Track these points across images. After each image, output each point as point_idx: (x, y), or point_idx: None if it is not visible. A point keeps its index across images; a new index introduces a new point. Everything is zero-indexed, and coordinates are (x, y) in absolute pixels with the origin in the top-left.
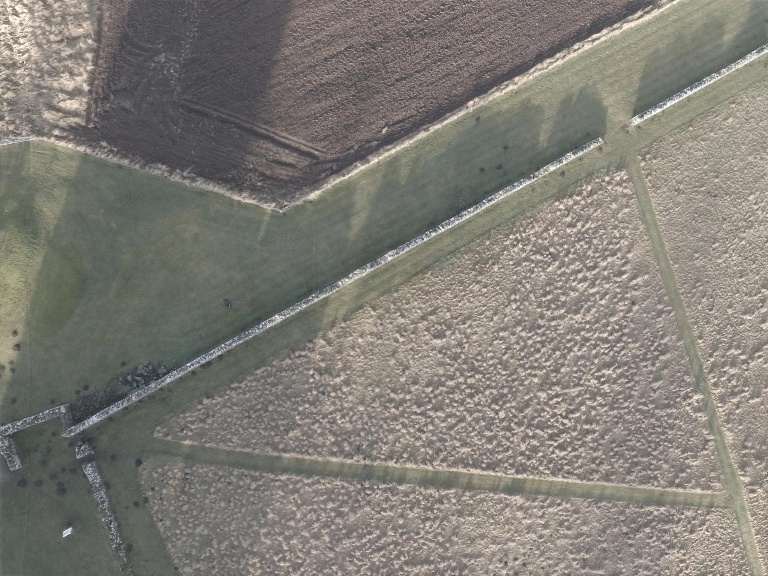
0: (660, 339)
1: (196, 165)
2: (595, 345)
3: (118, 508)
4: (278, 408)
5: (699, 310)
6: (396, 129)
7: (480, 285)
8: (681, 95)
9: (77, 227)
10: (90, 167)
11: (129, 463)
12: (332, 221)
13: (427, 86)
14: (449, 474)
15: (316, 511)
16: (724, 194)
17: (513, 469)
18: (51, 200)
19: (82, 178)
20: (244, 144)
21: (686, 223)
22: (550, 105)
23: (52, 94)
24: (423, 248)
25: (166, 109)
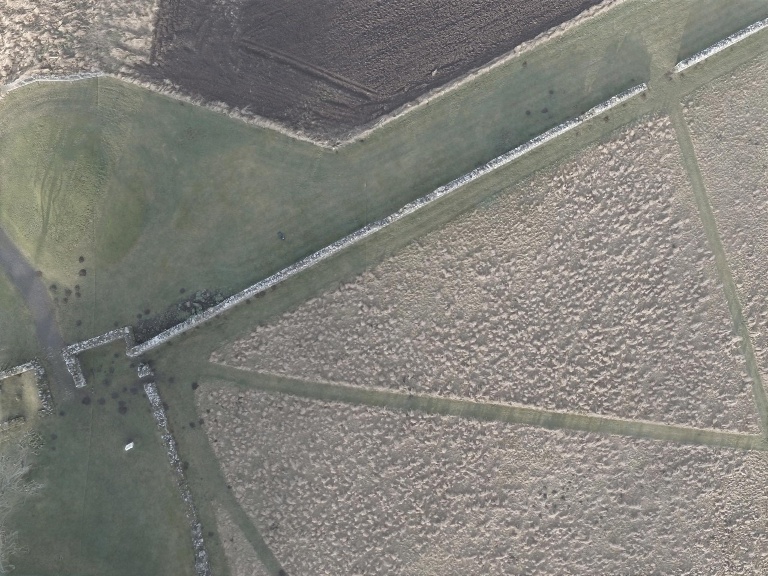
0: (700, 282)
1: (253, 103)
2: (636, 286)
3: (176, 428)
4: (328, 338)
5: (739, 255)
6: (445, 72)
7: (524, 224)
8: (725, 42)
9: (141, 159)
10: (154, 103)
11: (186, 386)
12: (382, 159)
13: (476, 31)
14: (491, 407)
15: (363, 438)
16: (765, 142)
17: (554, 404)
18: (117, 133)
19: (146, 113)
20: (299, 84)
21: (727, 170)
22: (595, 51)
23: (119, 33)
24: (469, 187)
25: (226, 49)
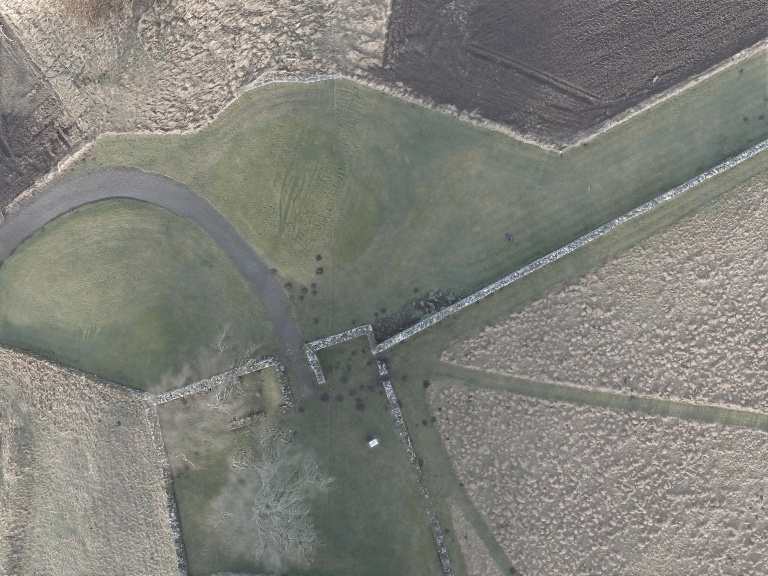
0: None
1: (481, 107)
2: None
3: (410, 425)
4: (553, 339)
5: None
6: (665, 78)
7: (742, 229)
8: None
9: (376, 160)
10: (387, 105)
11: (418, 384)
12: (605, 163)
13: (695, 38)
14: (709, 409)
15: (587, 438)
16: None
17: None
18: (353, 134)
19: (380, 115)
20: (526, 88)
21: None
22: None
23: (355, 36)
24: (689, 192)
25: (455, 53)
